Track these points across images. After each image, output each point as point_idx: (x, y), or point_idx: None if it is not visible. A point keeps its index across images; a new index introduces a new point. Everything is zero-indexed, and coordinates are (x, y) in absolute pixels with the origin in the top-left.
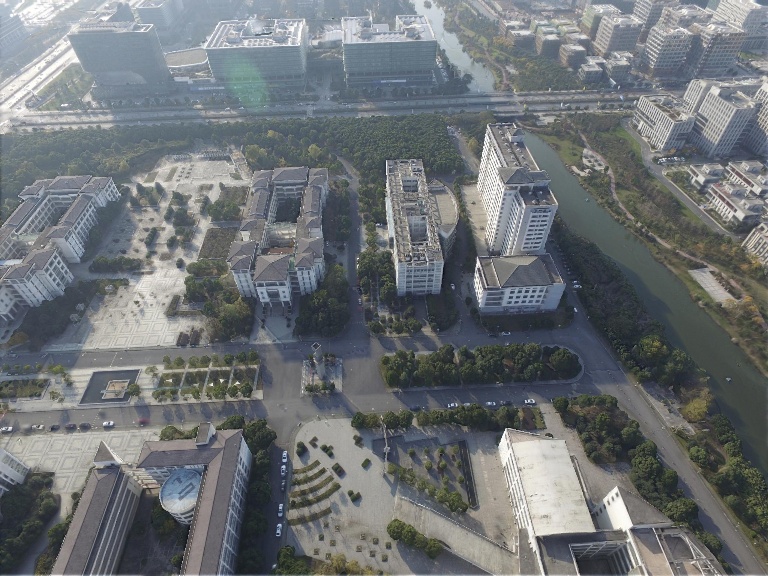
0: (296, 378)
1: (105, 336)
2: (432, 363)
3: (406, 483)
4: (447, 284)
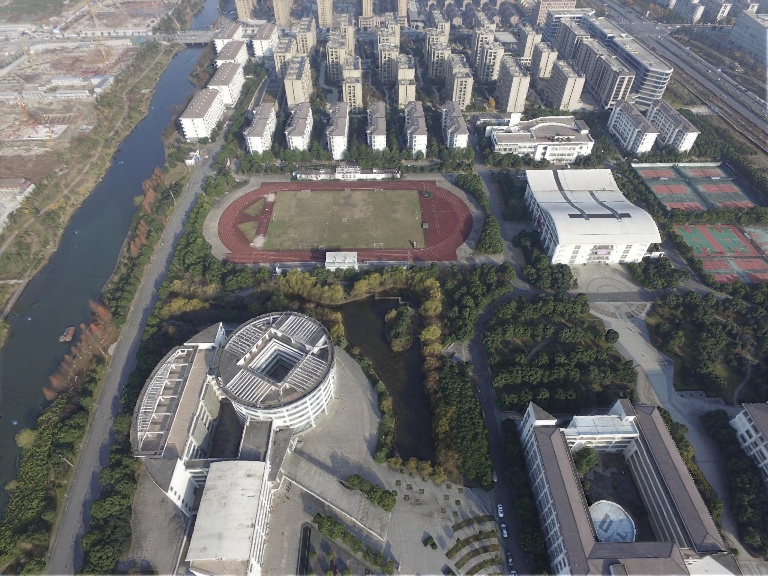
0: None
1: None
2: None
3: None
4: None
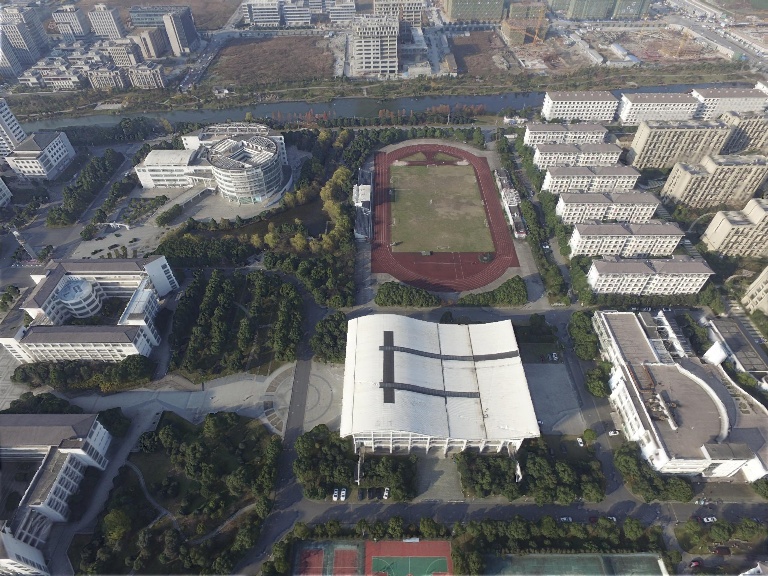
0: (24, 270)
1: None
2: None
3: (140, 221)
4: (10, 190)
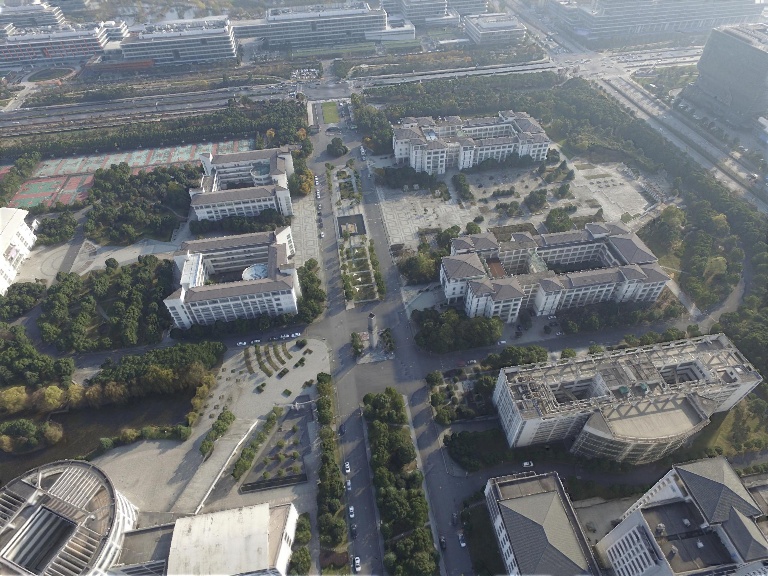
0: None
1: (393, 208)
2: (388, 435)
3: None
4: None
